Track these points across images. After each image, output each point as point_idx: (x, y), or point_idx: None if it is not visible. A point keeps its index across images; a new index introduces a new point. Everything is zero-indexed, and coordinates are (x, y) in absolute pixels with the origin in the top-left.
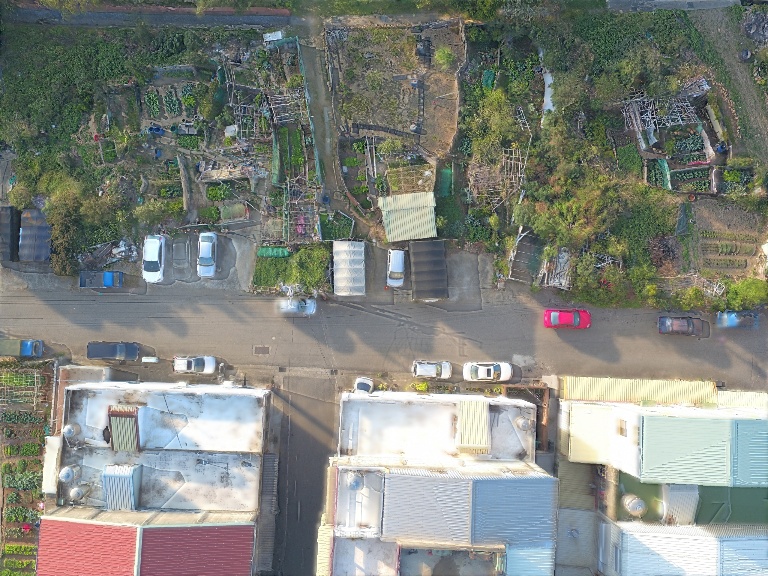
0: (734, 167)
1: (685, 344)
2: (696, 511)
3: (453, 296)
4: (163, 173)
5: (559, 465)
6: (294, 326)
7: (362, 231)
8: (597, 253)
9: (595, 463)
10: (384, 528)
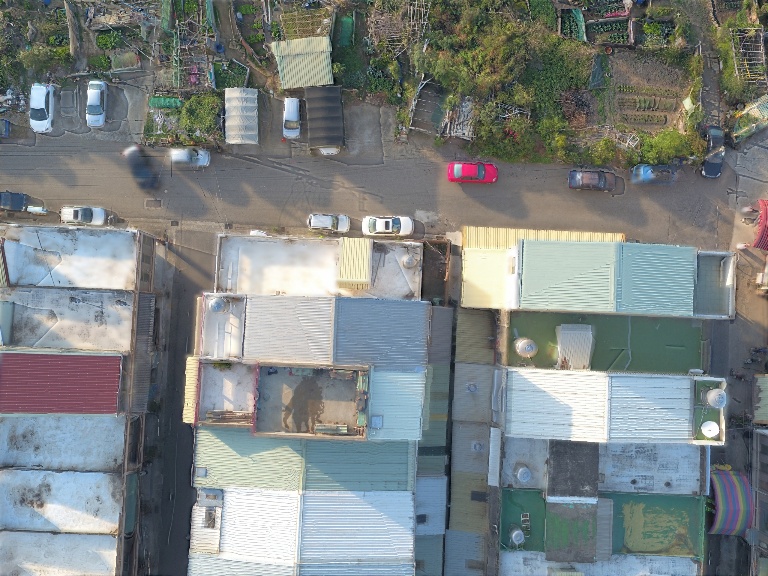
0: (654, 18)
1: (598, 201)
2: (590, 353)
3: (353, 149)
4: (52, 20)
5: (458, 318)
6: (187, 179)
7: (259, 81)
8: (504, 103)
9: (488, 308)
10: (245, 350)
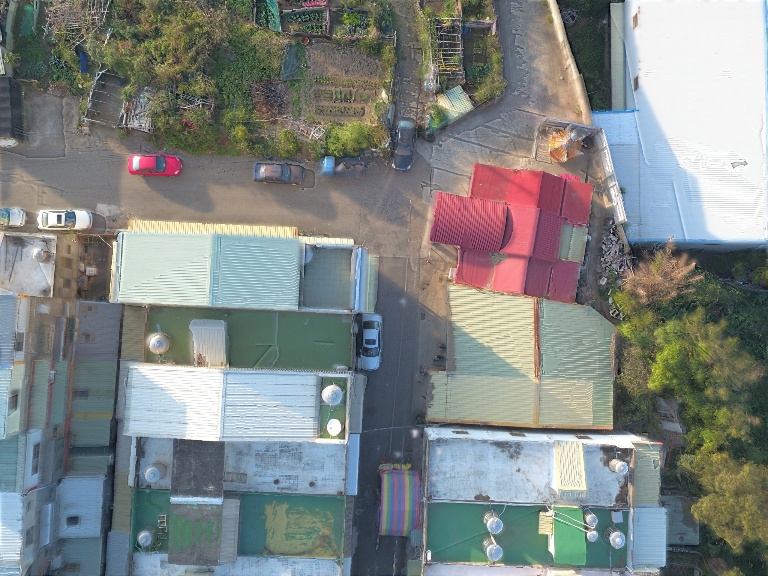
0: (353, 8)
1: (287, 194)
2: (225, 349)
3: (34, 142)
4: None
5: (124, 315)
6: None
7: None
8: (185, 94)
9: None
10: None
